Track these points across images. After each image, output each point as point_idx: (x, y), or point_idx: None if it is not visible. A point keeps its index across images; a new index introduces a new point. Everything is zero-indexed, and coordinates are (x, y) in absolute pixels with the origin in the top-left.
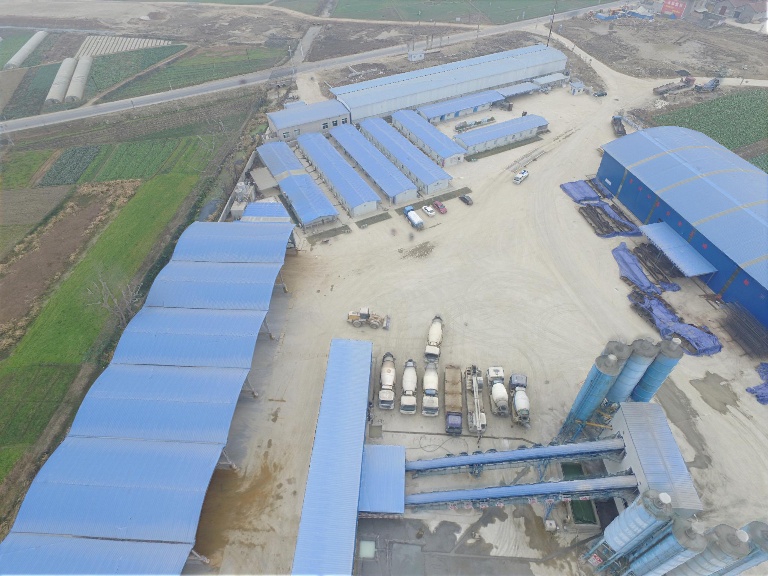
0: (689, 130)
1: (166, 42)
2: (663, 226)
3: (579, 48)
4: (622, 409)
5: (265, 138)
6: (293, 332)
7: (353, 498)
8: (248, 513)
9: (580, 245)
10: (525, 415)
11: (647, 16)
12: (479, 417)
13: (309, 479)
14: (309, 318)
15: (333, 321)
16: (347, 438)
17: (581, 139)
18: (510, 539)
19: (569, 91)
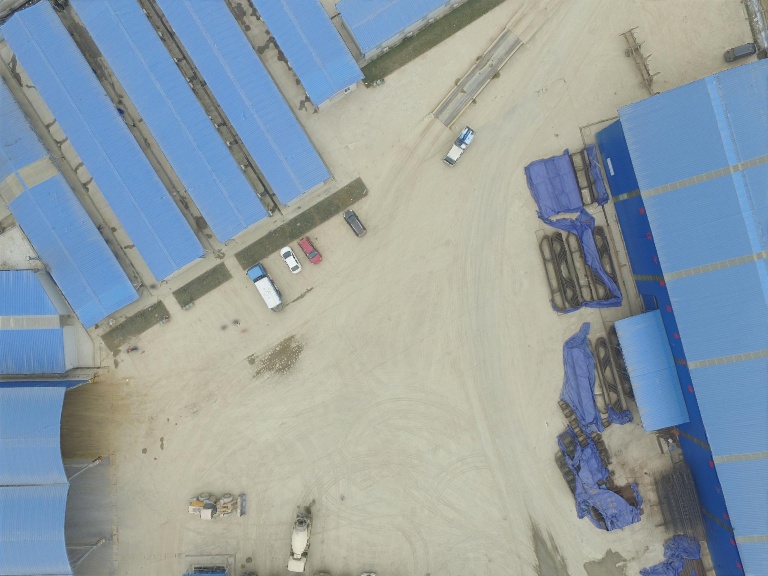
0: None
1: None
2: (653, 322)
3: None
4: None
5: None
6: (127, 524)
7: None
8: None
9: (521, 333)
10: None
11: None
12: None
13: None
14: (142, 500)
15: (174, 503)
16: None
17: None
18: None
19: None
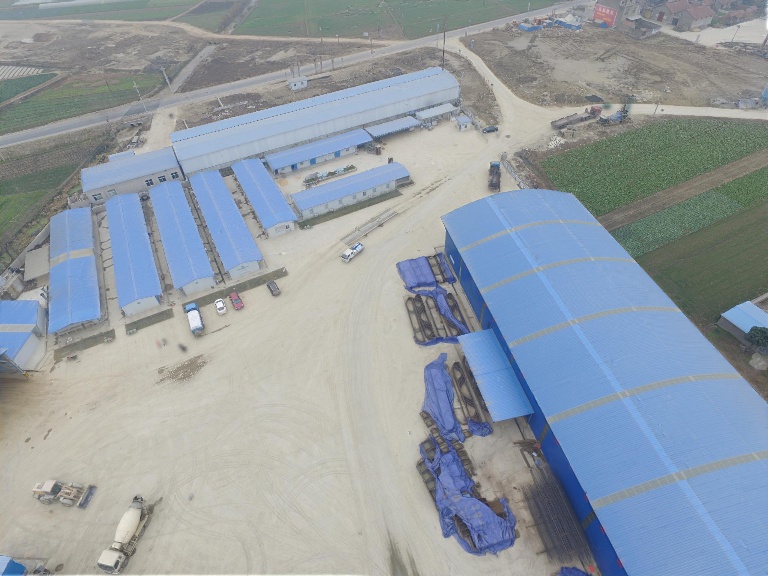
0: (551, 193)
1: (36, 70)
2: (488, 336)
3: (488, 68)
4: None
5: (75, 200)
6: None
7: None
8: None
9: (388, 358)
10: None
11: (574, 26)
12: None
13: None
14: None
15: (21, 493)
16: None
17: (447, 193)
18: None
19: (456, 126)
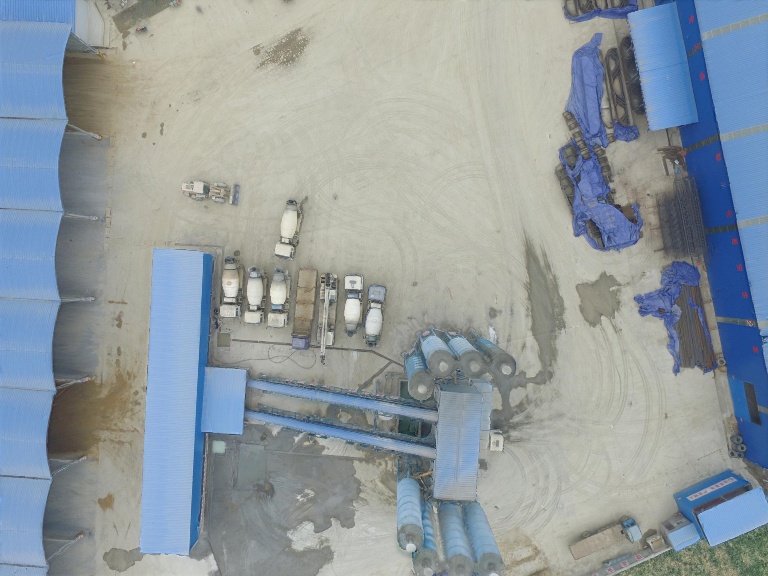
0: None
1: None
2: (667, 14)
3: None
4: (440, 400)
5: None
6: (120, 207)
7: (190, 433)
8: (112, 417)
9: (530, 39)
10: (371, 342)
11: None
12: (324, 341)
13: (147, 417)
14: (137, 184)
15: (168, 189)
16: (181, 375)
17: None
18: (341, 442)
19: None
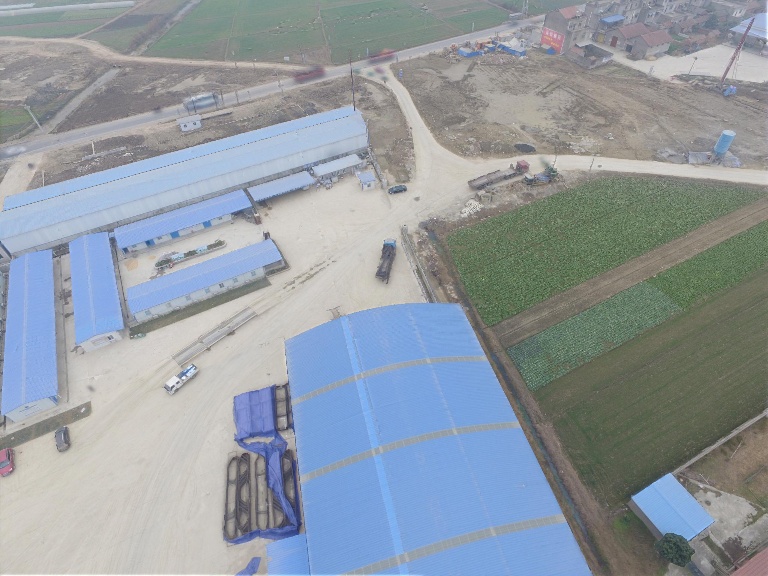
0: (429, 309)
1: None
2: None
3: (413, 104)
4: None
5: None
6: None
7: None
8: None
9: (179, 567)
10: None
11: (518, 52)
12: None
13: None
14: None
15: None
16: None
17: (325, 283)
18: None
19: (359, 183)
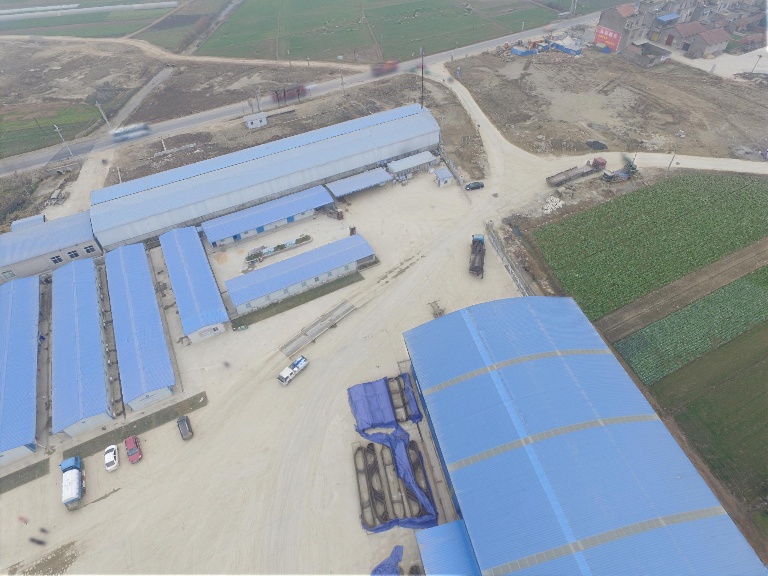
0: (546, 302)
1: None
2: (457, 534)
3: (475, 102)
4: None
5: None
6: None
7: None
8: None
9: (323, 554)
10: None
11: (573, 50)
12: None
13: None
14: None
15: None
16: None
17: (419, 278)
18: None
19: (435, 180)
